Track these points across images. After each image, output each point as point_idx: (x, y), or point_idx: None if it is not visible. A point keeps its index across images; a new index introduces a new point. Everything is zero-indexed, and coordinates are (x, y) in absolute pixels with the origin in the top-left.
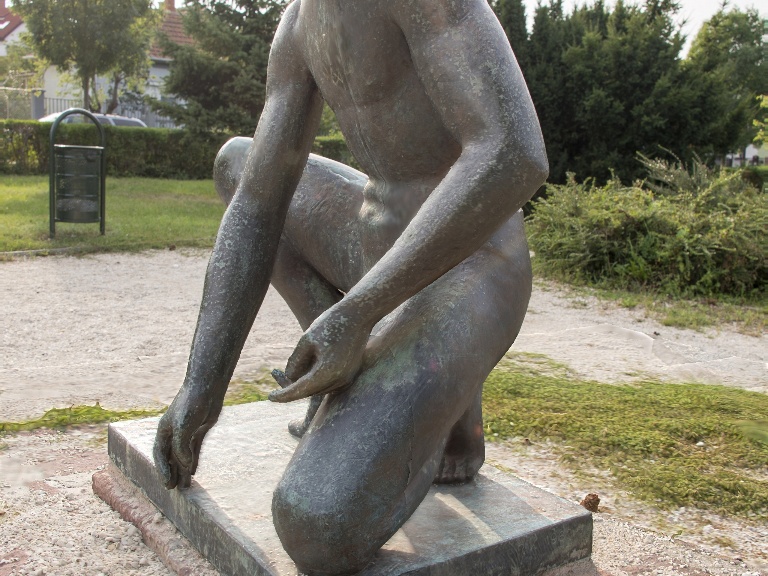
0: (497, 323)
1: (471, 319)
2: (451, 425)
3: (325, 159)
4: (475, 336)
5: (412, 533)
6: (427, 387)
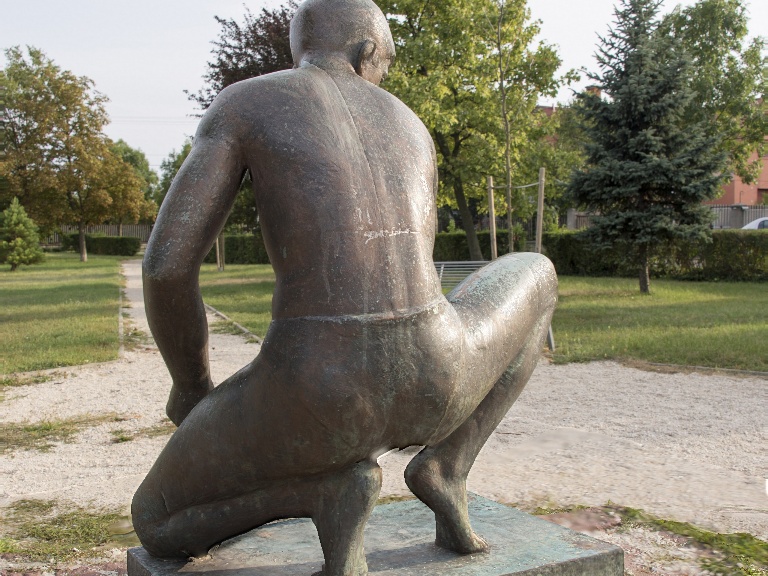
0: (240, 416)
1: (217, 403)
2: (199, 486)
3: (481, 270)
4: (213, 417)
5: (210, 572)
6: (173, 440)
